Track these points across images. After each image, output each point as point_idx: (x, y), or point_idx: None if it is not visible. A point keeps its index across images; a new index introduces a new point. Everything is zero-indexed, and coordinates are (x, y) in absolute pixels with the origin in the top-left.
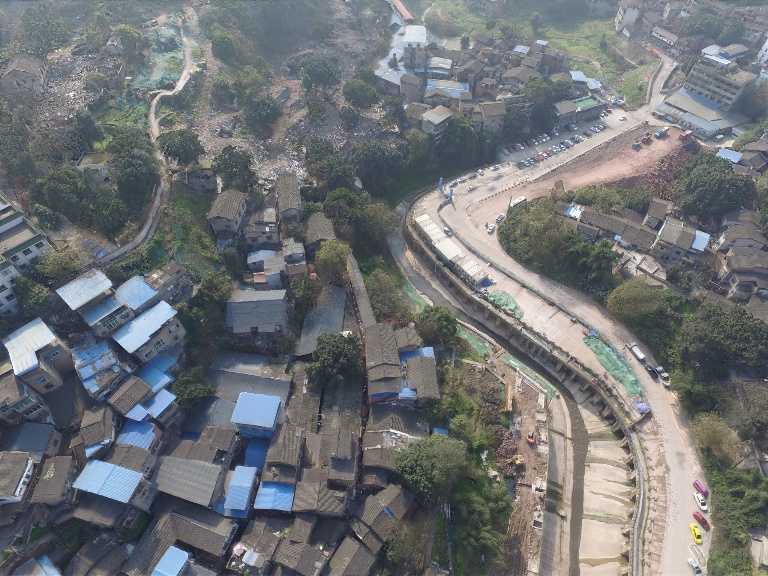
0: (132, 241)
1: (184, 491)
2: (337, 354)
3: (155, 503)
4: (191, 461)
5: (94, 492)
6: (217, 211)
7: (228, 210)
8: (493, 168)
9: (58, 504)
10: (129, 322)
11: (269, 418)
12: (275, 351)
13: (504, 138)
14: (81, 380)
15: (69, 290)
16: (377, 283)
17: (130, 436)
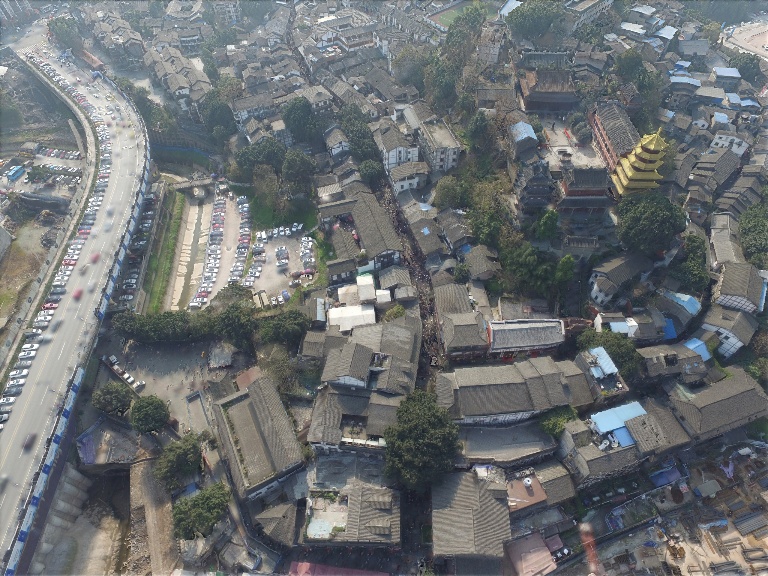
0: (636, 2)
1: (711, 95)
2: (751, 59)
3: (688, 106)
4: (707, 87)
5: (685, 82)
6: (655, 1)
7: (661, 1)
8: (751, 22)
9: (662, 91)
10: (657, 31)
11: (737, 74)
12: (699, 70)
13: (751, 7)
14: (653, 47)
15: (638, 9)
16: (735, 50)
17: (680, 72)
